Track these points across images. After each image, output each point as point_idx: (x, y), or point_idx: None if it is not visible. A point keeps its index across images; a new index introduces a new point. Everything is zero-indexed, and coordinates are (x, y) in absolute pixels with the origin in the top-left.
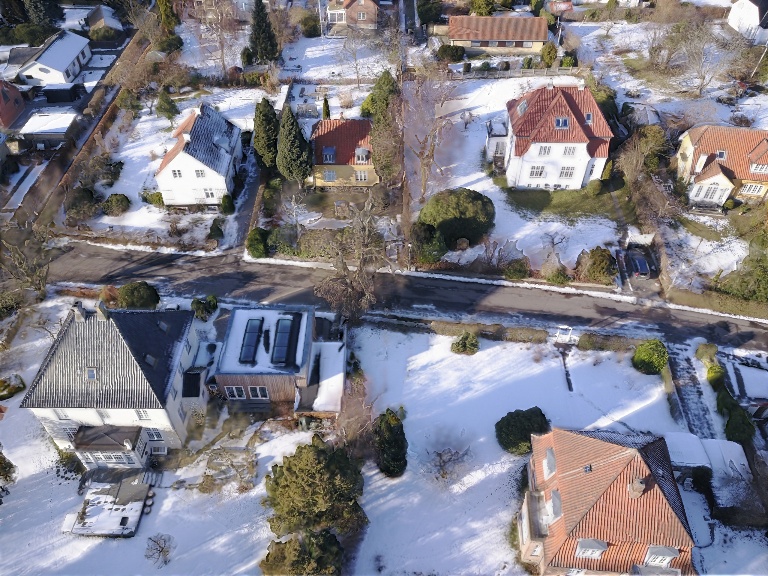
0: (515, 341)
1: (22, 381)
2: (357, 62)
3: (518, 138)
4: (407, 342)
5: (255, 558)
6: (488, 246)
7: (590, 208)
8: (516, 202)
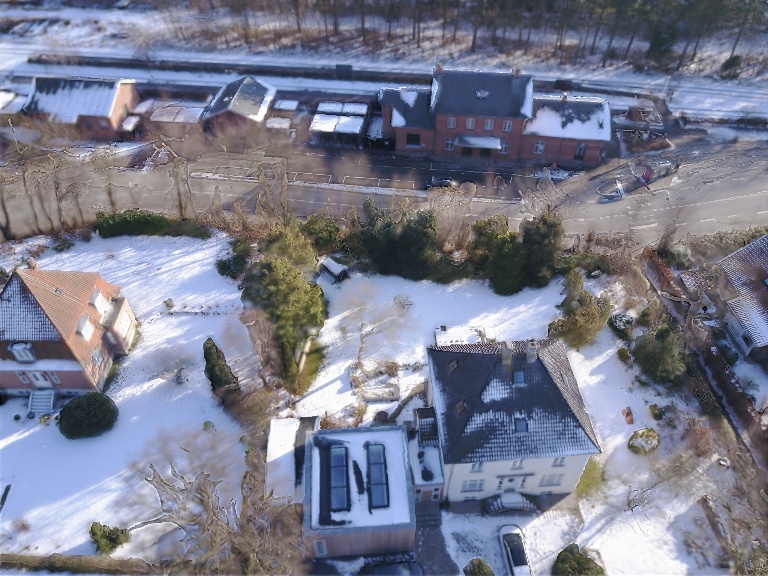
0: None
1: (635, 447)
2: None
3: None
4: None
5: (337, 319)
6: None
7: None
8: None
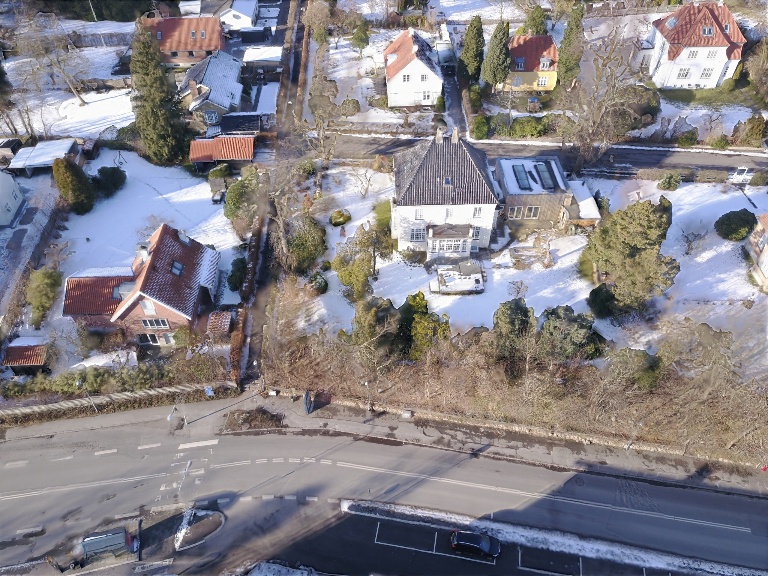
0: (702, 182)
1: (349, 213)
2: (502, 4)
3: (671, 45)
4: (622, 185)
5: (578, 298)
6: (664, 122)
7: (728, 100)
8: (668, 98)
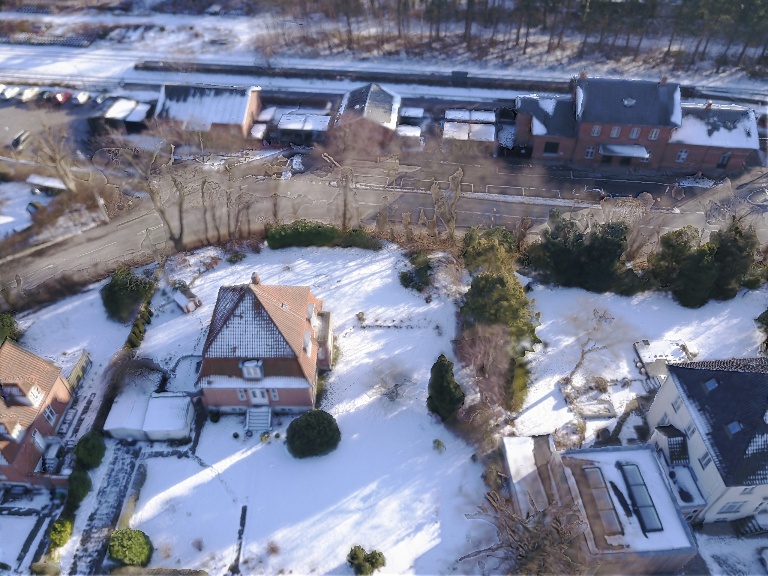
0: None
1: None
2: None
3: None
4: (445, 572)
5: None
6: None
7: None
8: None
